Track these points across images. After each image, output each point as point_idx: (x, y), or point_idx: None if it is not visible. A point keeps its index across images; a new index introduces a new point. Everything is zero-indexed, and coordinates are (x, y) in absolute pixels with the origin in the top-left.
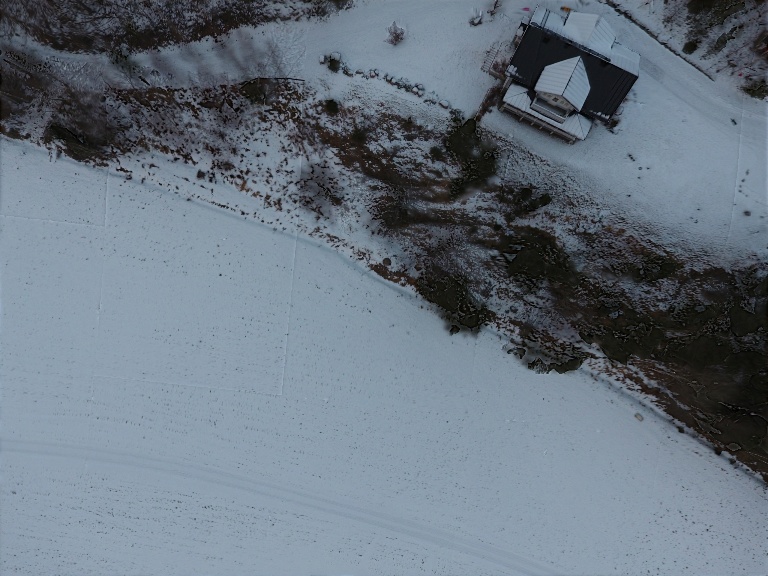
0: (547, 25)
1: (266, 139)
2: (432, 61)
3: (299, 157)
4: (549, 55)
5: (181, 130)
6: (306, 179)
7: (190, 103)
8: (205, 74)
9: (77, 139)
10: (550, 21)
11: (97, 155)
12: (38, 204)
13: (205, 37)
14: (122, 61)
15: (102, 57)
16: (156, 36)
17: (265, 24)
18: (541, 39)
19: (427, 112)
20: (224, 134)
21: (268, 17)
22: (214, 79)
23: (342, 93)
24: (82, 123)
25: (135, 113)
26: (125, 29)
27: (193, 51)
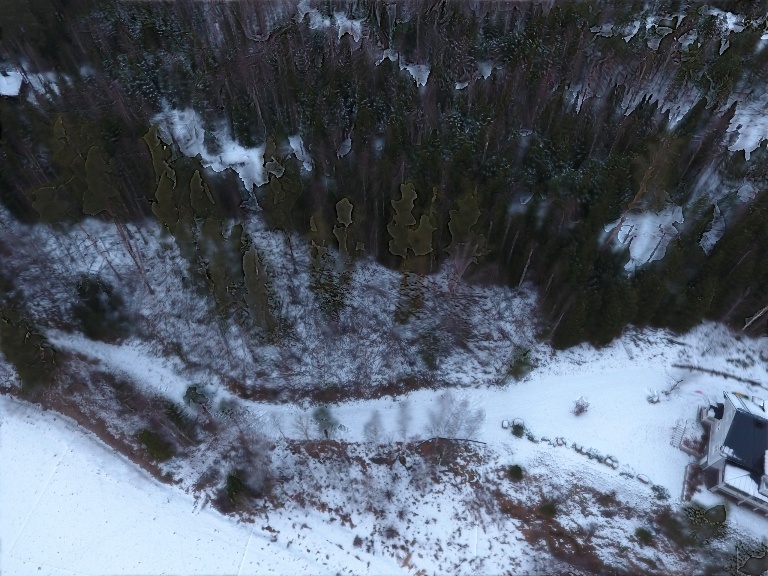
0: (751, 411)
1: (438, 503)
2: (619, 433)
3: (475, 528)
4: (766, 439)
5: (345, 486)
6: (482, 557)
7: (361, 458)
8: (382, 430)
9: (244, 491)
10: (750, 407)
11: (246, 509)
12: (159, 567)
13: (384, 396)
14: (301, 412)
15: (282, 408)
16: (340, 393)
17: (445, 389)
18: (753, 424)
19: (625, 486)
20: (391, 494)
21: (449, 383)
22: (390, 435)
23: (527, 459)
24: (243, 471)
25: (300, 464)
26: (314, 385)
27: (371, 408)
